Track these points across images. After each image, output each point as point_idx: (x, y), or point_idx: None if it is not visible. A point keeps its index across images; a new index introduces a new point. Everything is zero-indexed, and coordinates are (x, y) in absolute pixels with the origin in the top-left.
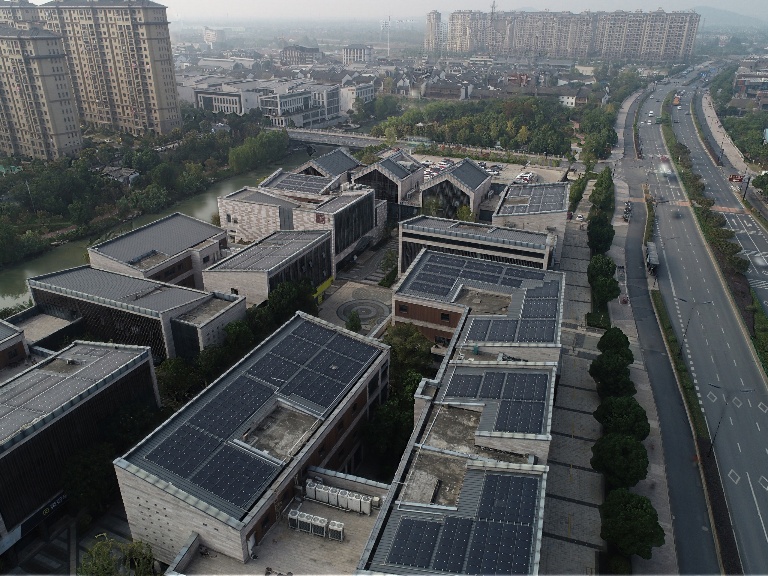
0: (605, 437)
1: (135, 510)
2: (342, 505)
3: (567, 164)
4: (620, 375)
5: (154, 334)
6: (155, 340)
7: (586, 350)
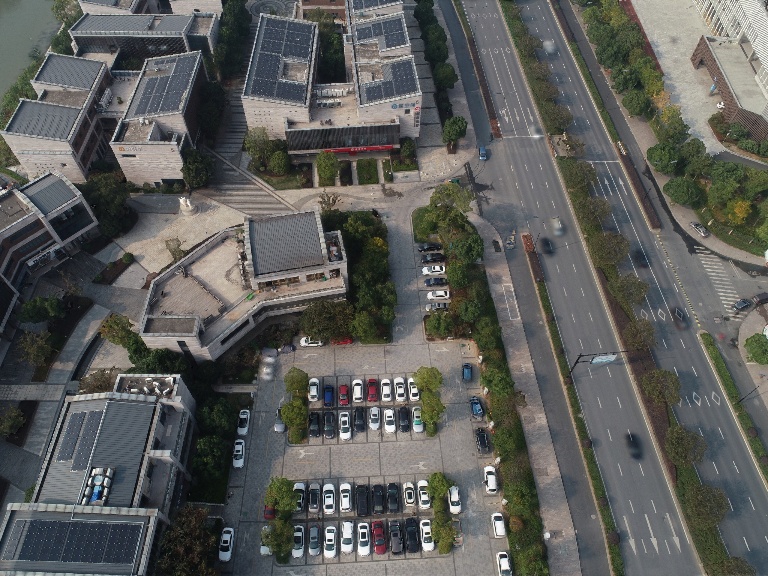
0: (429, 44)
1: (252, 118)
2: (334, 95)
3: None
4: (429, 13)
5: (178, 47)
6: (179, 51)
7: (407, 4)
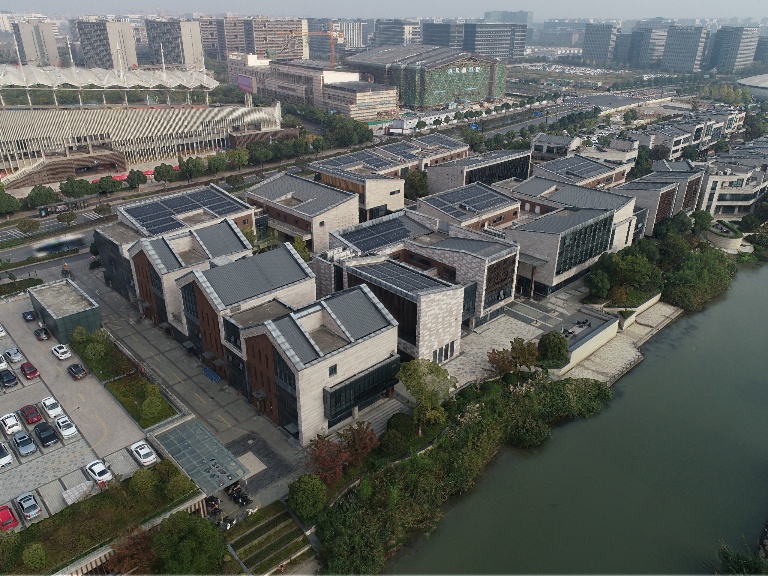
0: None
1: None
2: None
3: None
4: None
5: None
6: None
7: None
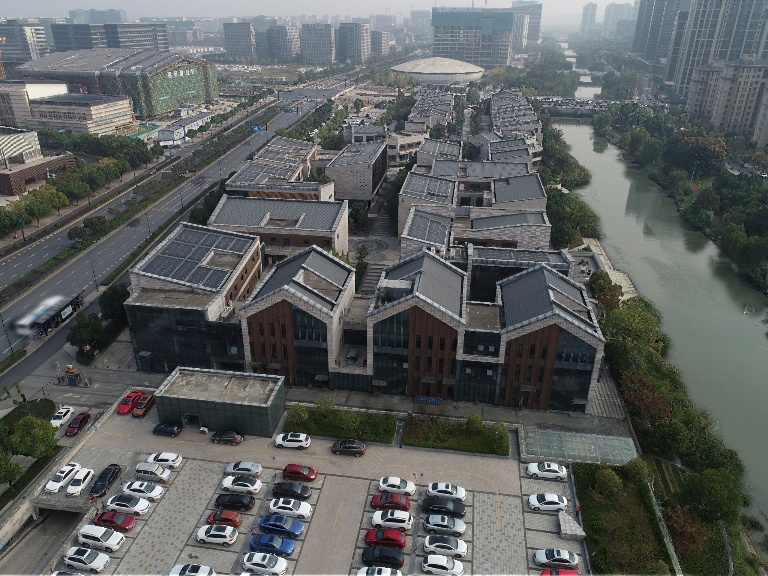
0: None
1: None
2: None
3: None
4: None
5: None
6: None
7: None
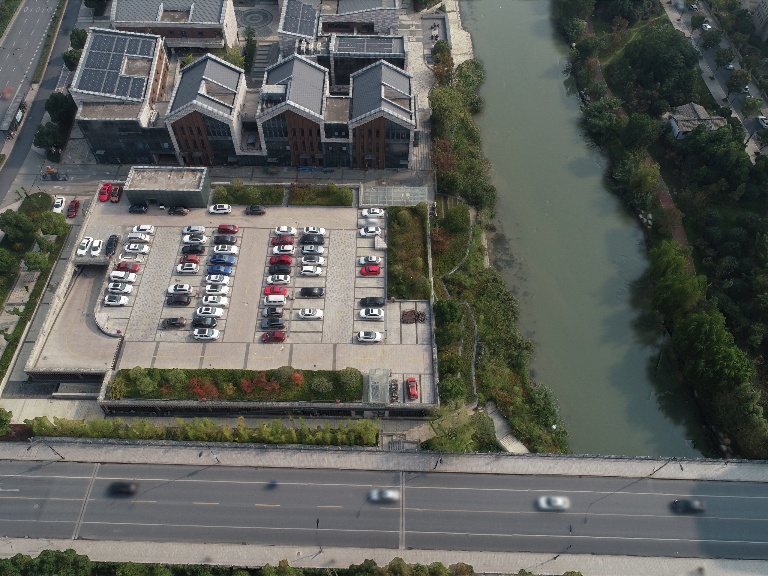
0: None
1: None
2: None
3: (4, 501)
4: None
5: None
6: None
7: (109, 21)
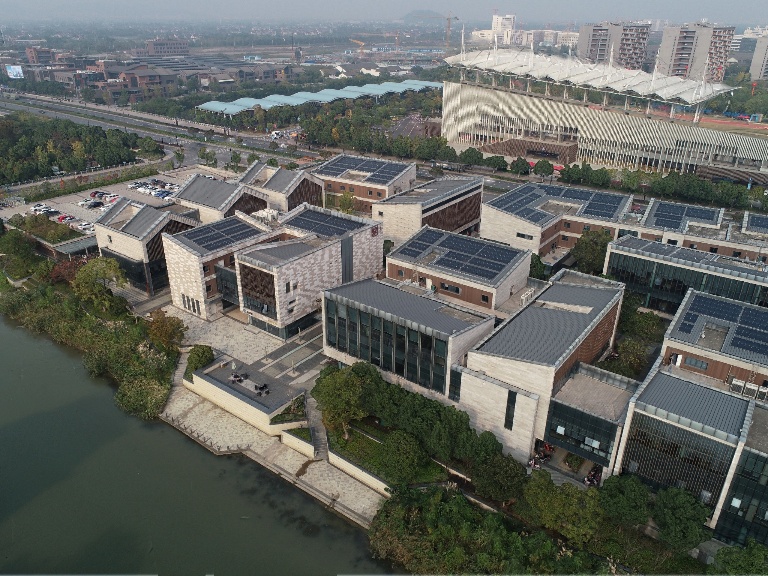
0: None
1: None
2: None
3: None
4: None
5: None
6: None
7: None
